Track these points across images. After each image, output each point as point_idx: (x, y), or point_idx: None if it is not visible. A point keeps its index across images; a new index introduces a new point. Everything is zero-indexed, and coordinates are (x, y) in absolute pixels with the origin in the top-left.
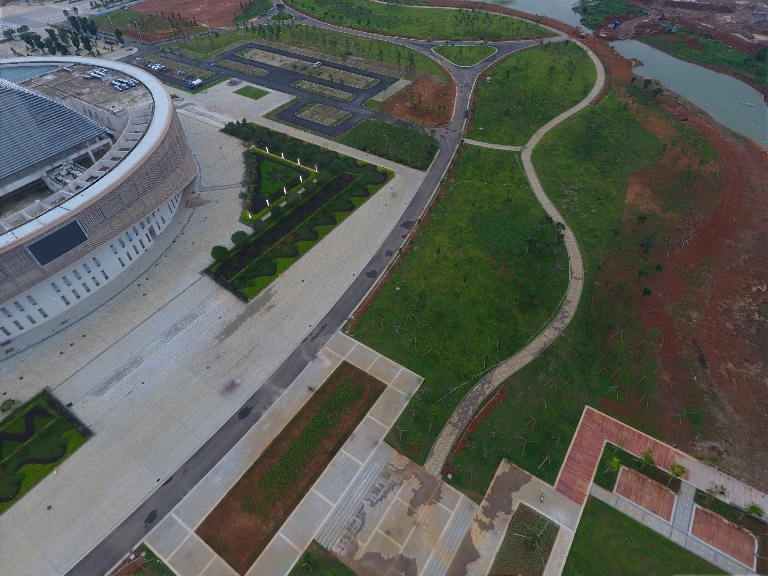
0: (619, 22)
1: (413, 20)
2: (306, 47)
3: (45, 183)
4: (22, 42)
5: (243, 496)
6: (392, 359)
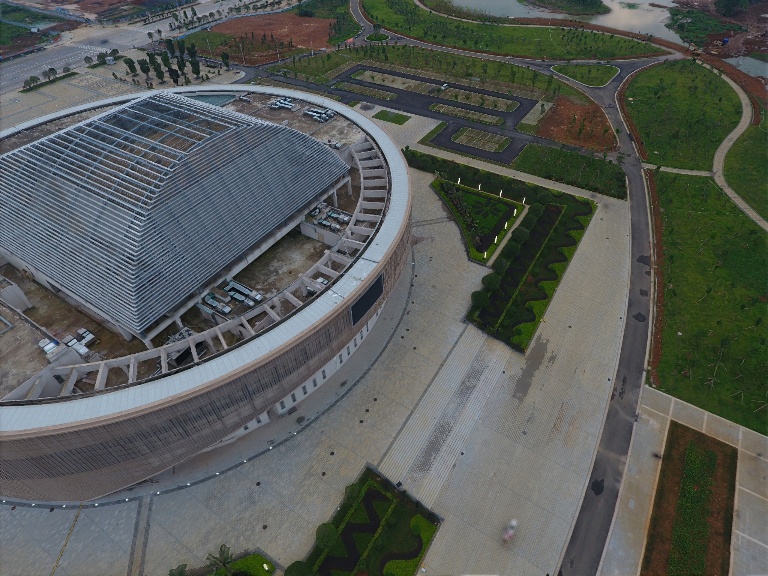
0: (726, 39)
1: (517, 39)
2: (421, 68)
3: (300, 228)
4: (117, 66)
5: None
6: (723, 417)
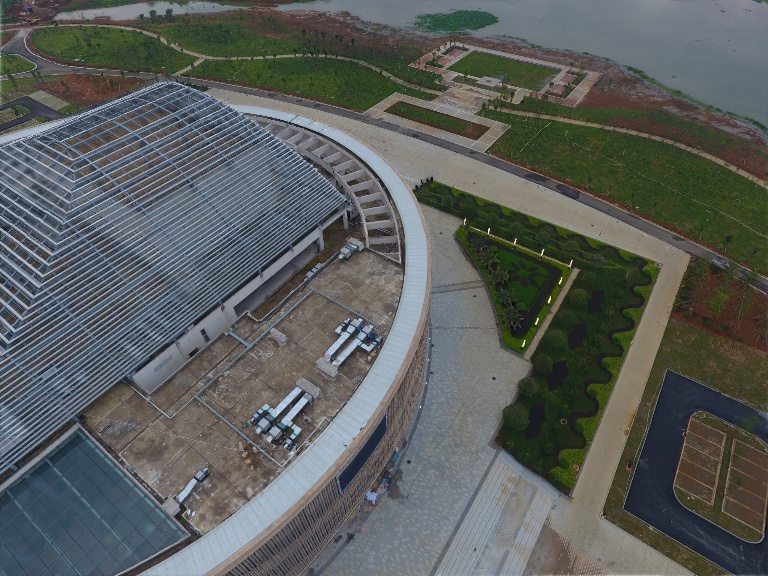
0: None
1: None
2: None
3: None
4: None
5: (459, 131)
6: (383, 99)
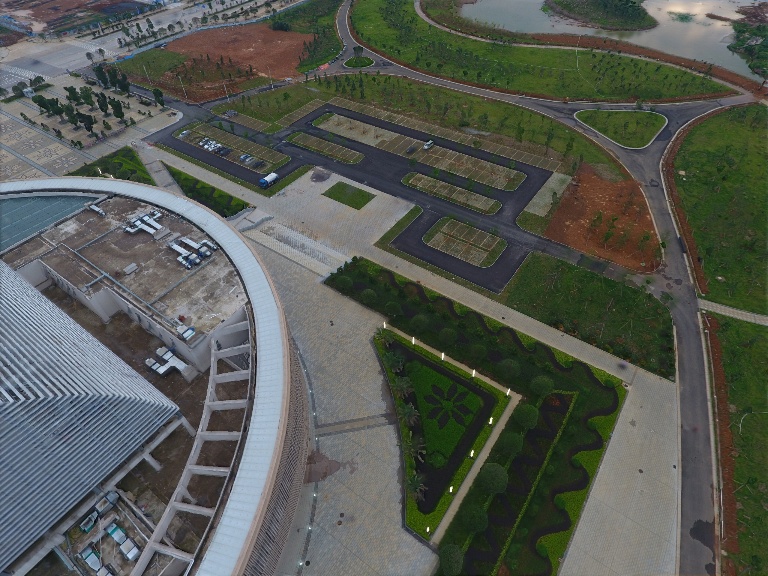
0: None
1: (534, 69)
2: (403, 112)
3: None
4: None
5: None
6: None
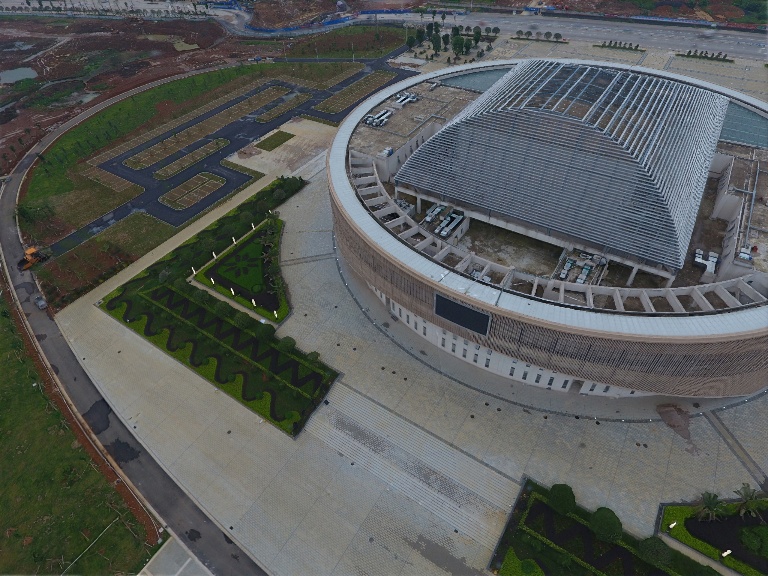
0: None
1: None
2: None
3: None
4: None
5: None
6: None
